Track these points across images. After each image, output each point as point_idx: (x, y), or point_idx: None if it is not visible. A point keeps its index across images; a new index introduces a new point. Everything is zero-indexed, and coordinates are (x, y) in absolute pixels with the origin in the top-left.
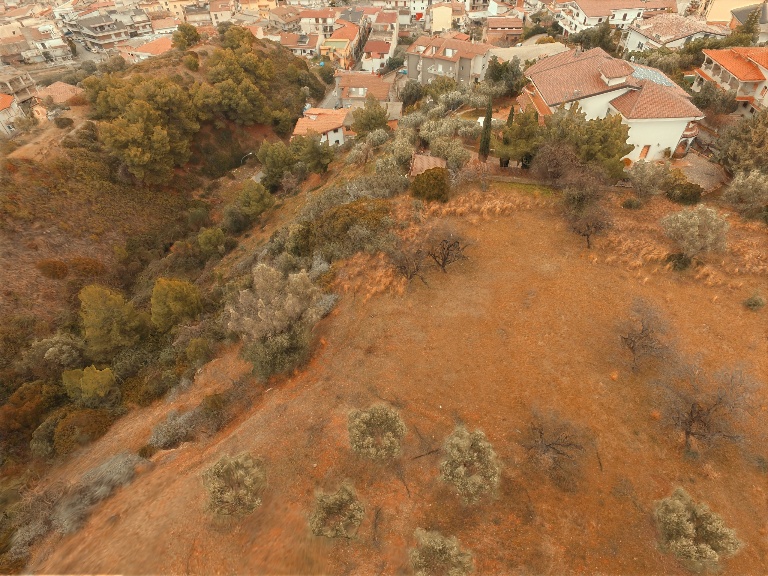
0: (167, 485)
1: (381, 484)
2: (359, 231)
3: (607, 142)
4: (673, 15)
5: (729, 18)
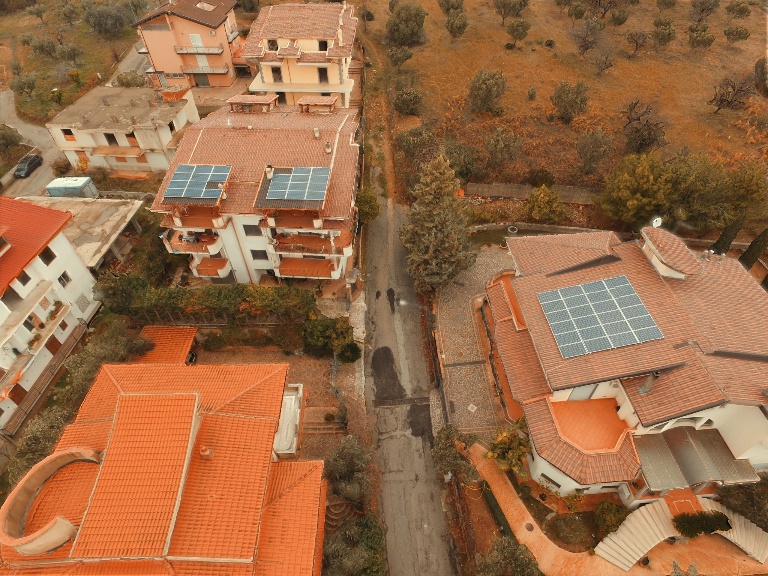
0: None
1: None
2: None
3: None
4: None
5: None
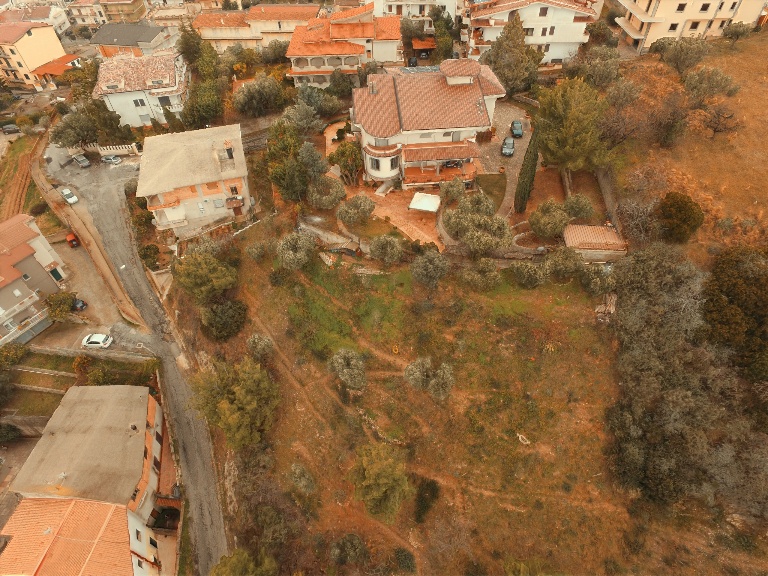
0: None
1: None
2: None
3: None
4: (115, 62)
5: (45, 59)
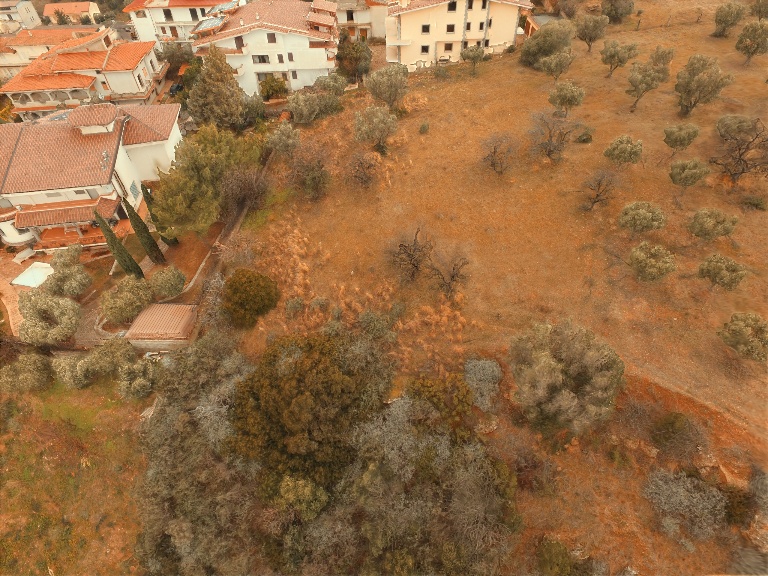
0: (766, 431)
1: (662, 279)
2: (360, 351)
3: (233, 147)
4: None
5: None
